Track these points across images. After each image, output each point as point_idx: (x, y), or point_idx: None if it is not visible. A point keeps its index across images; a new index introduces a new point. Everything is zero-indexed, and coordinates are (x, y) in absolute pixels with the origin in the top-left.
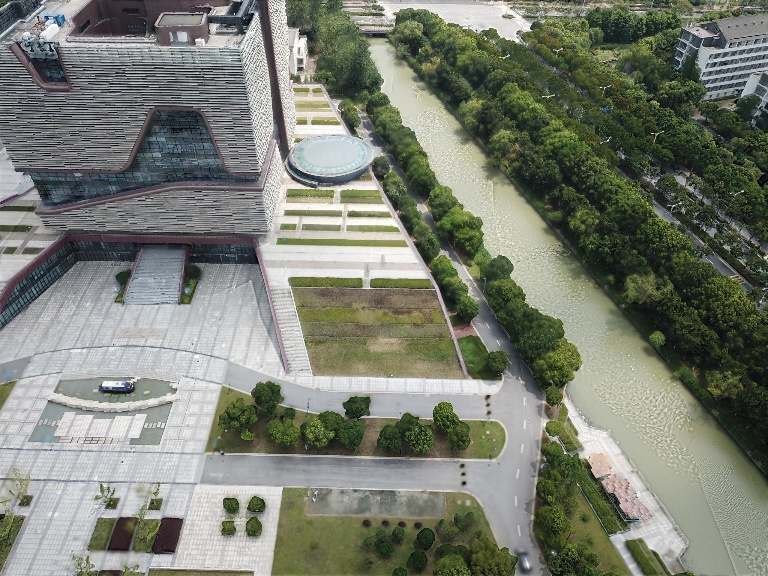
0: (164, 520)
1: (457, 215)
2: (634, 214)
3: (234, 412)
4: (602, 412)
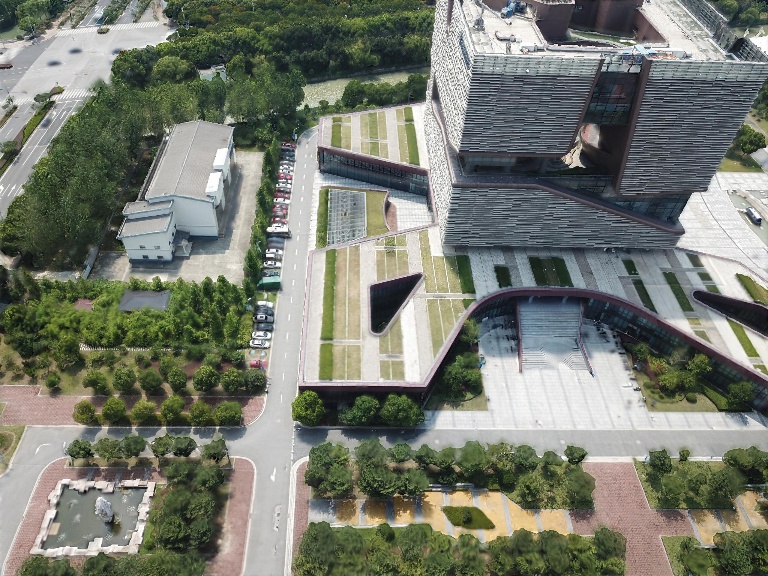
0: None
1: None
2: None
3: (761, 134)
4: None
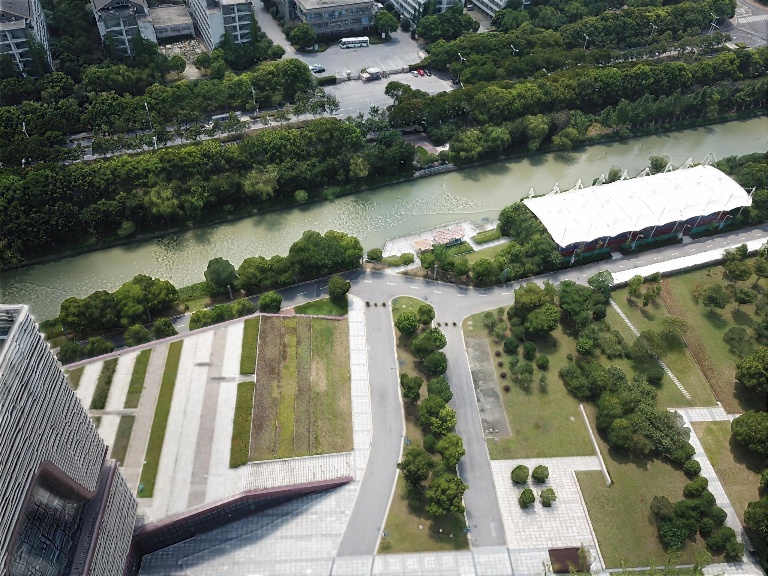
0: (558, 568)
1: (132, 292)
2: (173, 162)
3: None
4: (364, 245)
